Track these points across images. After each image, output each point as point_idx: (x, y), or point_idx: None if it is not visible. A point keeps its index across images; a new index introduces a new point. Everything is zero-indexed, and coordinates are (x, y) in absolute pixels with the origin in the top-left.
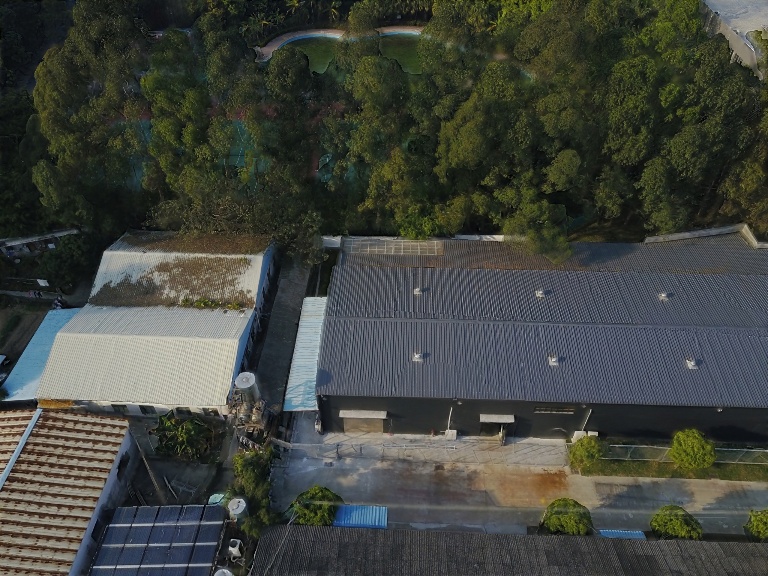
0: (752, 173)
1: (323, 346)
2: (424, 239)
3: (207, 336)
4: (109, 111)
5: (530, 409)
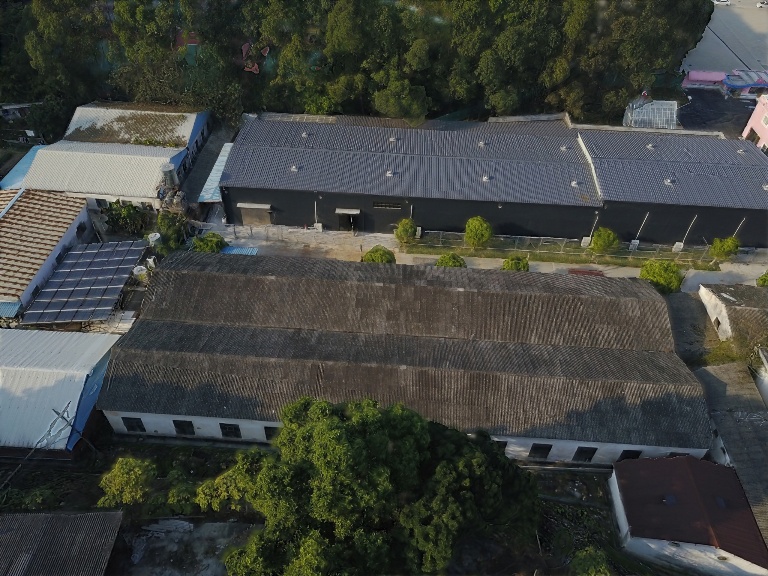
0: (560, 66)
1: (229, 160)
2: (323, 114)
3: (147, 155)
4: None
5: (370, 204)
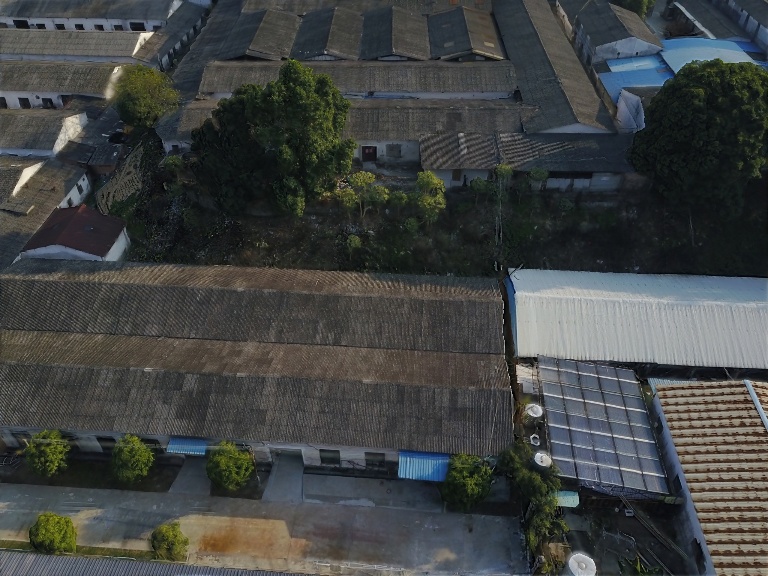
0: None
1: None
2: None
3: None
4: None
5: None
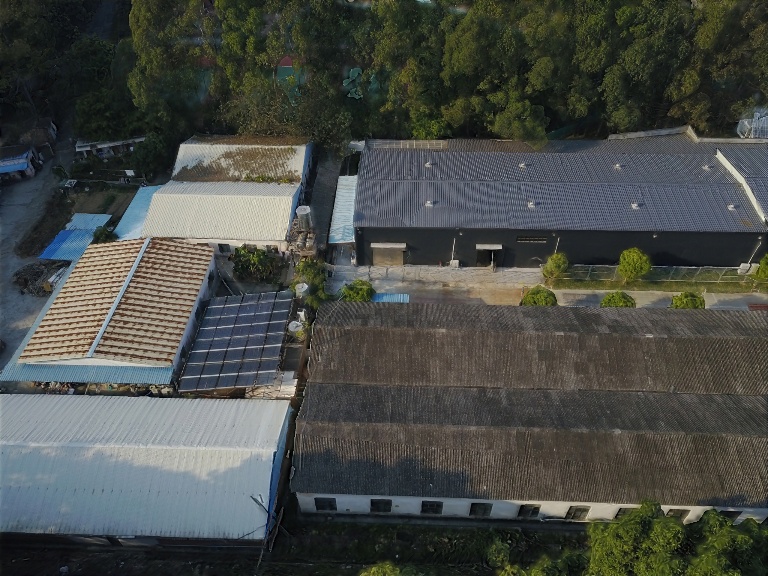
0: (690, 78)
1: (357, 197)
2: (432, 139)
3: (268, 195)
4: (189, 28)
5: (514, 239)
